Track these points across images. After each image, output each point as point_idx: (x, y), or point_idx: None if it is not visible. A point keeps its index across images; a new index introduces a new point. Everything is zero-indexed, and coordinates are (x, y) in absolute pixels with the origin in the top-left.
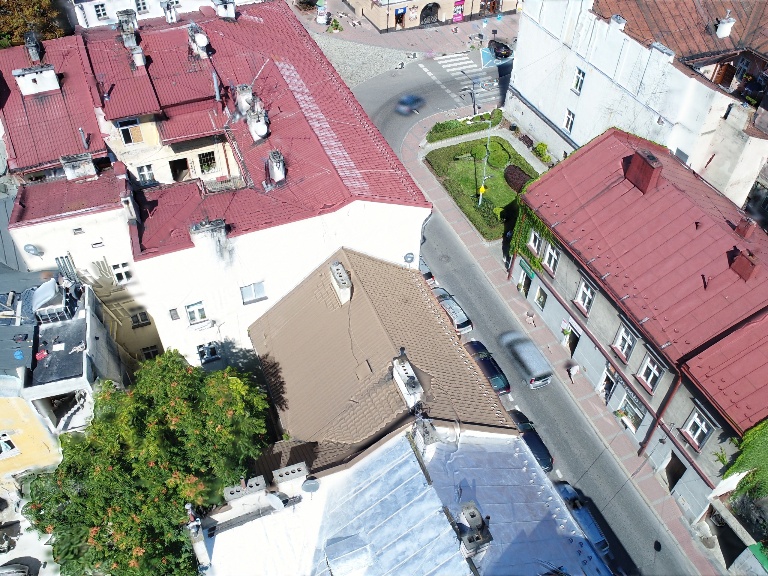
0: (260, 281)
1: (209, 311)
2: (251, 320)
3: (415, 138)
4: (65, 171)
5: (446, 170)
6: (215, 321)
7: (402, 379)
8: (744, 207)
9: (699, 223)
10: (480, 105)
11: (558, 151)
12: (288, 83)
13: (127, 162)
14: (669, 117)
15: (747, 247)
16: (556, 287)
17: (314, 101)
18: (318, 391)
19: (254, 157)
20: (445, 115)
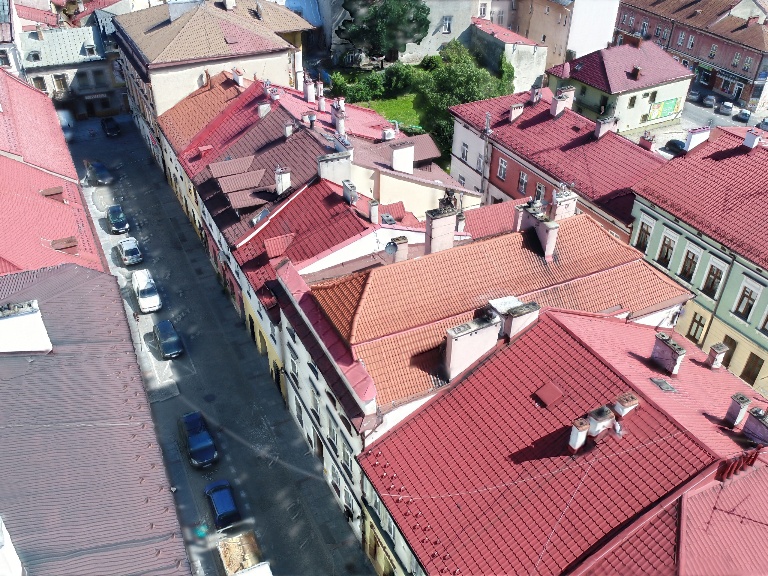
0: None
1: None
2: None
3: None
4: (82, 6)
5: None
6: None
7: None
8: None
9: None
10: None
11: None
12: None
13: None
14: None
15: None
16: None
17: None
18: None
19: None
20: None
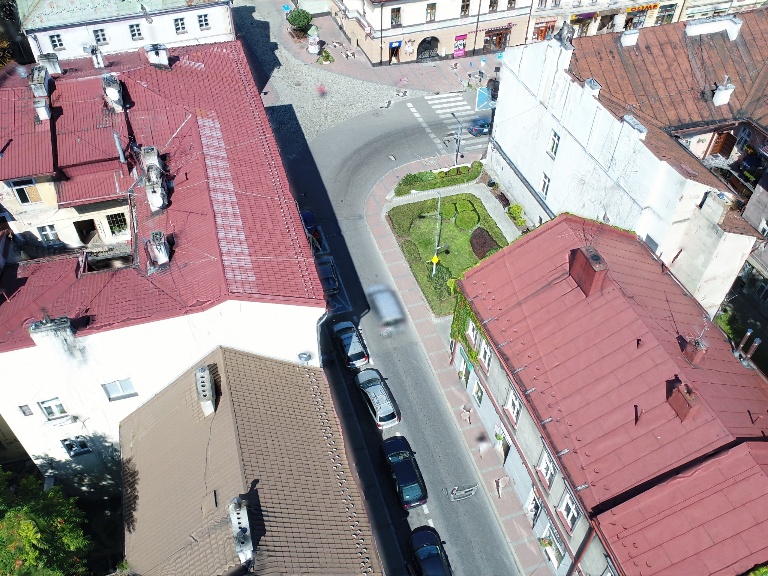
0: (125, 378)
1: (69, 407)
2: (121, 415)
3: (384, 189)
4: None
5: (407, 230)
6: (77, 416)
7: (232, 530)
8: (726, 301)
9: (641, 341)
10: (464, 153)
11: (534, 215)
12: (204, 145)
13: (25, 222)
14: (639, 199)
15: (690, 378)
16: (490, 386)
17: (228, 167)
18: (165, 516)
19: (147, 230)
20: (423, 163)
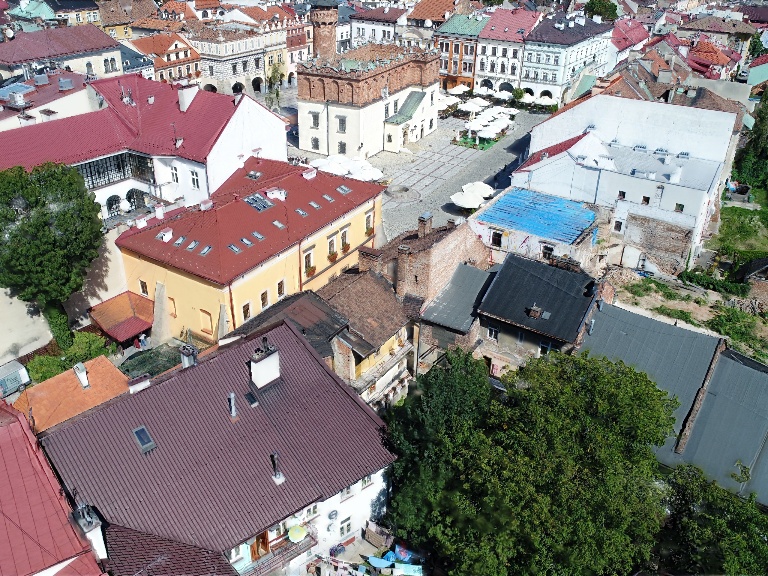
0: None
1: None
2: None
3: None
4: None
5: None
6: None
7: (759, 28)
8: None
9: (760, 24)
10: None
11: None
12: None
13: None
14: None
15: None
16: None
17: None
18: None
19: None
20: None
